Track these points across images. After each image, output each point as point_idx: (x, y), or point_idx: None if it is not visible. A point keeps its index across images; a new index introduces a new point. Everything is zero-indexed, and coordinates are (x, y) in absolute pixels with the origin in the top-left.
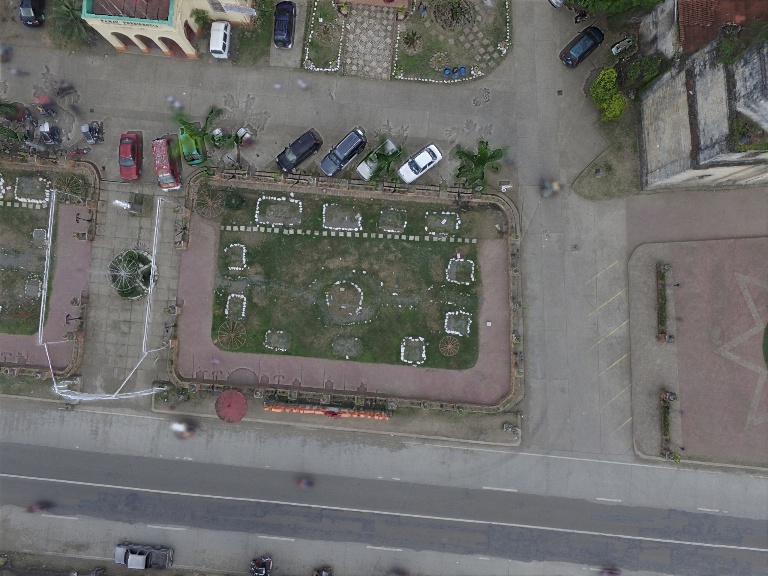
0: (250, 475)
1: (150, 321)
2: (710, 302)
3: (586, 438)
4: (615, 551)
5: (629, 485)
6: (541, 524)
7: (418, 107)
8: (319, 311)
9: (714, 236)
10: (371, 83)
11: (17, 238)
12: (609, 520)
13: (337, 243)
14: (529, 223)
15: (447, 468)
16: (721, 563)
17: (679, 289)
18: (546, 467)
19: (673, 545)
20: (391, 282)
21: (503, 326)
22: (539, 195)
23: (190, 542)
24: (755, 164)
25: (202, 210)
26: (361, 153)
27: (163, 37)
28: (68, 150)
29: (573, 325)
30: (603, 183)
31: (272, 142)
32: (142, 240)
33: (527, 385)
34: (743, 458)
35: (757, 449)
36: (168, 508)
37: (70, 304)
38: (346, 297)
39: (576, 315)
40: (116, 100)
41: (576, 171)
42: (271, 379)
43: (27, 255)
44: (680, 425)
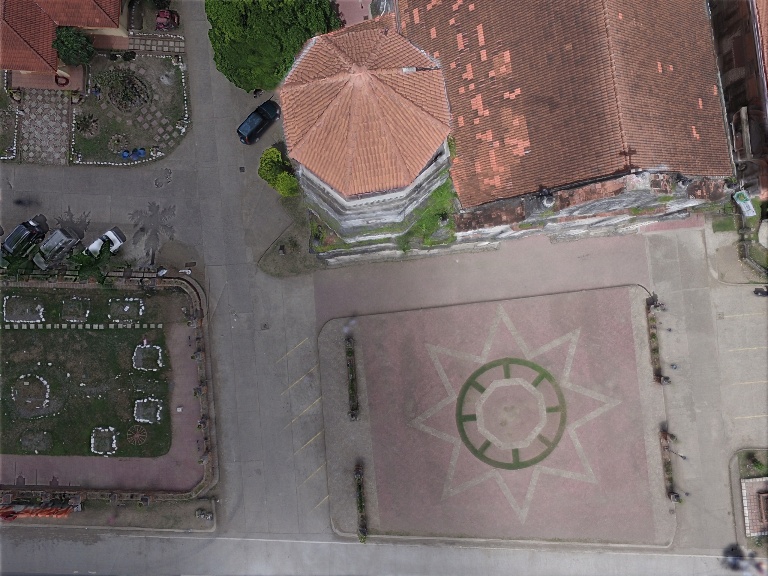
0: None
1: None
2: (401, 374)
3: (283, 519)
4: None
5: (328, 564)
6: None
7: (99, 191)
8: (5, 406)
9: (403, 307)
10: (50, 169)
11: None
12: None
13: (21, 336)
14: (217, 304)
15: (143, 558)
16: None
17: (369, 363)
18: (244, 551)
19: None
20: (78, 372)
21: (195, 410)
22: (225, 275)
23: None
24: None
25: None
26: (42, 242)
27: None
28: None
29: (266, 405)
30: (288, 260)
31: None
32: None
33: (222, 469)
34: (440, 530)
35: (454, 520)
36: None
37: None
38: (31, 391)
39: (268, 395)
40: None
41: (262, 248)
42: None
43: None
44: (376, 500)
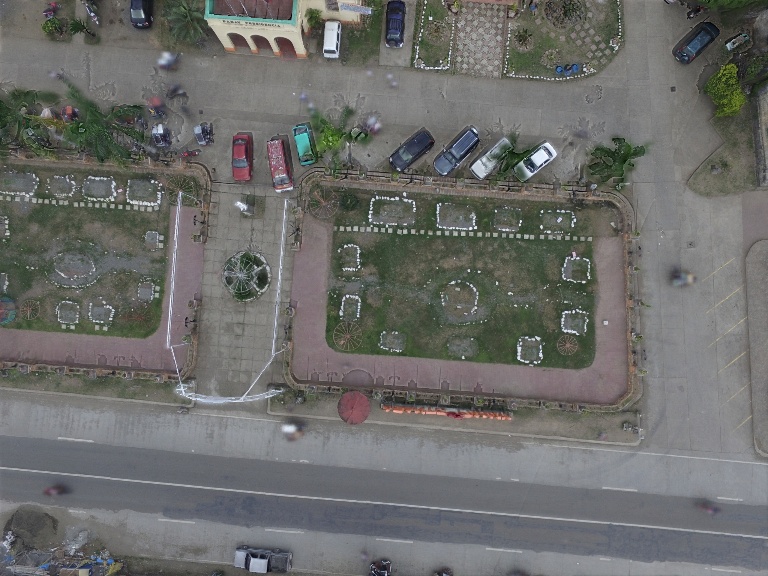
0: (367, 477)
1: (264, 323)
2: None
3: (706, 437)
4: (737, 551)
5: (750, 484)
6: (662, 524)
7: (530, 105)
8: (434, 311)
9: None
10: (482, 81)
11: (129, 241)
12: (731, 519)
13: (451, 243)
14: (644, 220)
15: (566, 468)
16: None
17: None
18: (666, 466)
19: None
20: (506, 281)
21: (620, 325)
22: (654, 192)
23: (308, 545)
24: None
25: (316, 211)
26: (473, 152)
27: (280, 37)
28: (180, 152)
29: (690, 323)
30: (719, 179)
31: (383, 142)
32: (254, 242)
33: (645, 384)
34: None
35: None
36: (285, 511)
37: (188, 307)
38: (462, 297)
39: (693, 313)
40: (225, 101)
41: (691, 168)
42: (386, 380)
43: (139, 258)
44: None
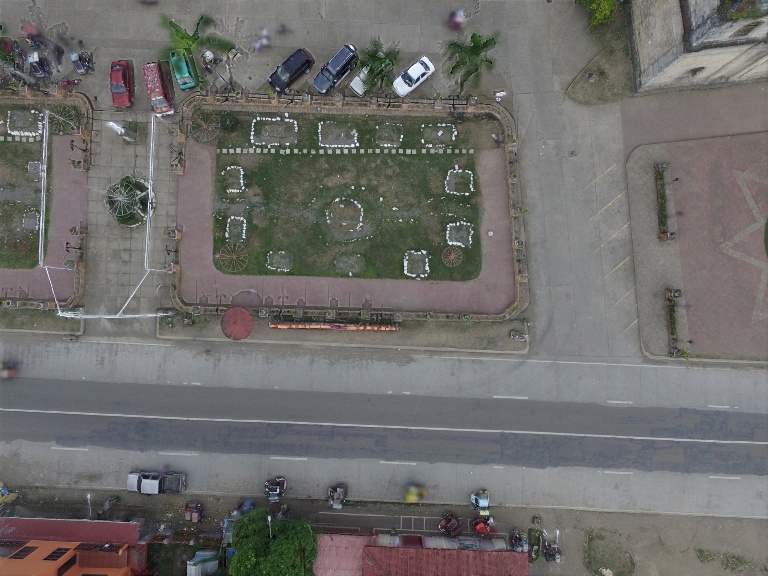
0: (259, 397)
1: (150, 248)
2: (710, 200)
3: (593, 342)
4: (628, 453)
5: (639, 386)
6: (553, 430)
7: (408, 21)
8: (320, 229)
9: (710, 134)
10: (360, 0)
11: (12, 172)
12: (621, 422)
13: (334, 161)
14: (525, 131)
15: (456, 379)
16: (734, 459)
17: (678, 189)
18: (555, 373)
19: (686, 443)
20: (390, 197)
21: (505, 235)
22: (534, 103)
23: (202, 467)
24: (748, 43)
25: (197, 134)
26: (354, 70)
27: None
28: (59, 80)
29: (574, 230)
30: (597, 87)
31: (264, 64)
32: (138, 168)
33: (532, 292)
34: (751, 353)
35: (764, 343)
36: (178, 434)
37: (69, 232)
38: (346, 214)
39: (577, 220)
40: (105, 30)
41: (569, 77)
42: (275, 300)
43: (23, 189)
44: (686, 324)
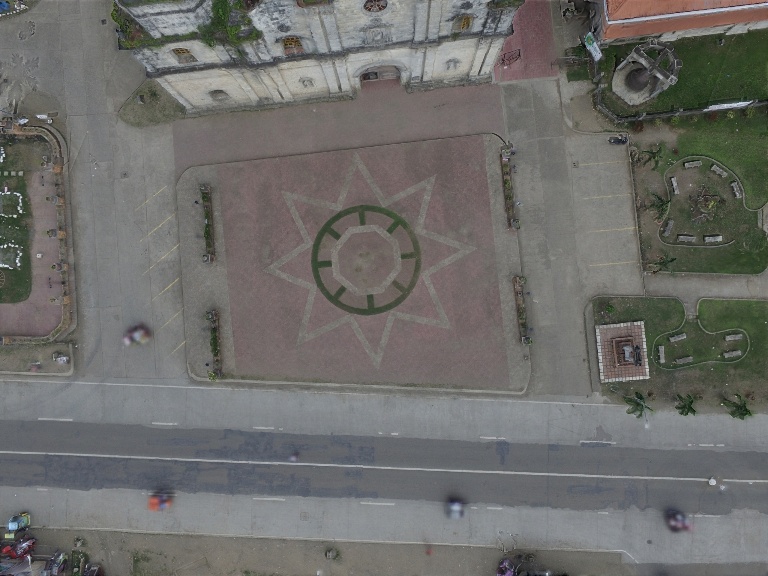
0: None
1: None
2: (258, 221)
3: (141, 364)
4: (172, 474)
5: (184, 408)
6: (97, 452)
7: None
8: None
9: (261, 156)
10: None
11: None
12: (165, 444)
13: None
14: (78, 153)
15: (2, 401)
16: (279, 480)
17: (227, 210)
18: (101, 395)
19: (230, 465)
20: None
21: (55, 257)
22: (87, 125)
23: None
24: (207, 69)
25: None
26: None
27: None
28: None
29: (125, 252)
30: (147, 109)
31: None
32: None
33: (80, 314)
34: (295, 374)
35: (309, 365)
36: None
37: None
38: None
39: (127, 242)
40: None
41: (123, 99)
42: None
43: None
44: (232, 345)
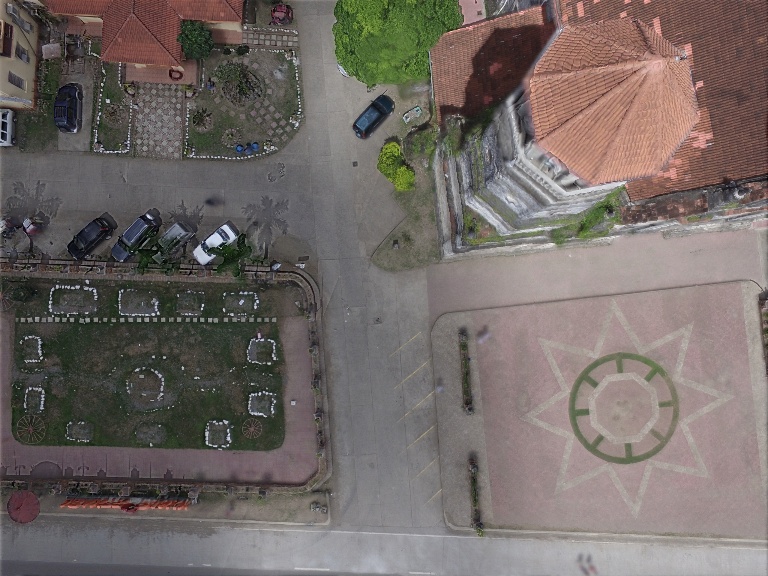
0: (58, 570)
1: None
2: (514, 369)
3: (397, 512)
4: None
5: (441, 557)
6: None
7: (212, 185)
8: (120, 399)
9: (516, 302)
10: (163, 163)
11: None
12: None
13: (135, 329)
14: (330, 298)
15: (258, 551)
16: None
17: (483, 357)
18: (357, 544)
19: None
20: (192, 366)
21: (308, 404)
22: (339, 269)
23: None
24: None
25: None
26: (156, 235)
27: None
28: None
29: (379, 399)
30: (402, 254)
31: (65, 229)
32: None
33: (335, 462)
34: (553, 524)
35: (567, 514)
36: None
37: None
38: (146, 384)
39: (381, 389)
40: None
41: (375, 243)
42: (75, 471)
43: None
44: (490, 494)
